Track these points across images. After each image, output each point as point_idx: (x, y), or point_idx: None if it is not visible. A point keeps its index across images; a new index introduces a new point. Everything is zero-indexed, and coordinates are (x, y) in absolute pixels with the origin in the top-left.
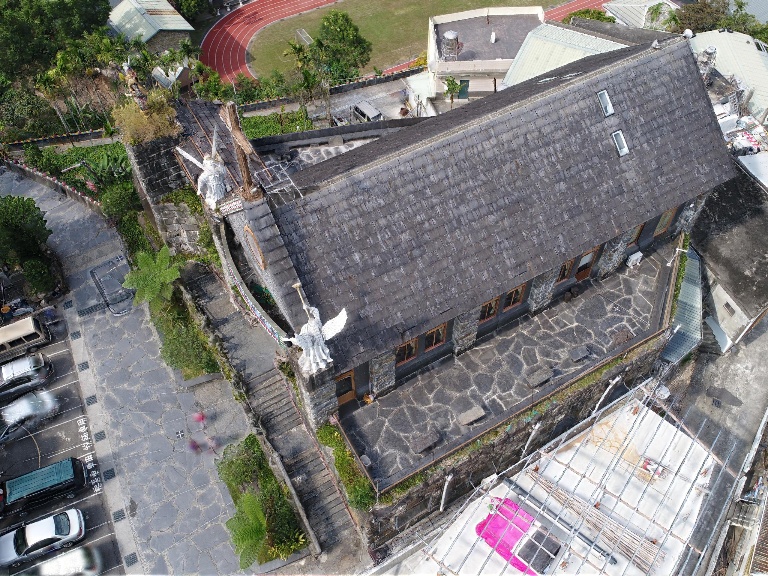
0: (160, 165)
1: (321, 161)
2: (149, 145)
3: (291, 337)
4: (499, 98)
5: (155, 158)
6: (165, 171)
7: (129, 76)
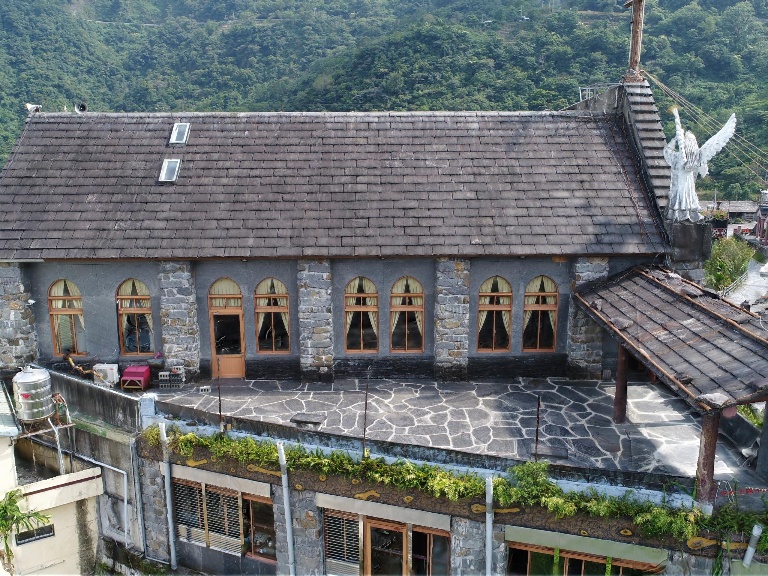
0: None
1: (468, 448)
2: None
3: None
4: (238, 189)
5: None
6: None
7: None
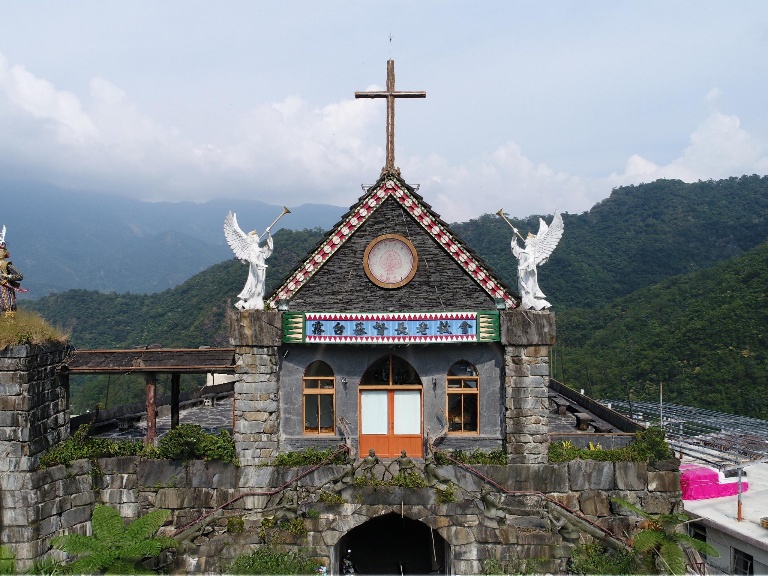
0: (43, 392)
1: None
2: (39, 349)
3: (497, 304)
4: None
5: (41, 376)
6: (46, 406)
7: (2, 254)
